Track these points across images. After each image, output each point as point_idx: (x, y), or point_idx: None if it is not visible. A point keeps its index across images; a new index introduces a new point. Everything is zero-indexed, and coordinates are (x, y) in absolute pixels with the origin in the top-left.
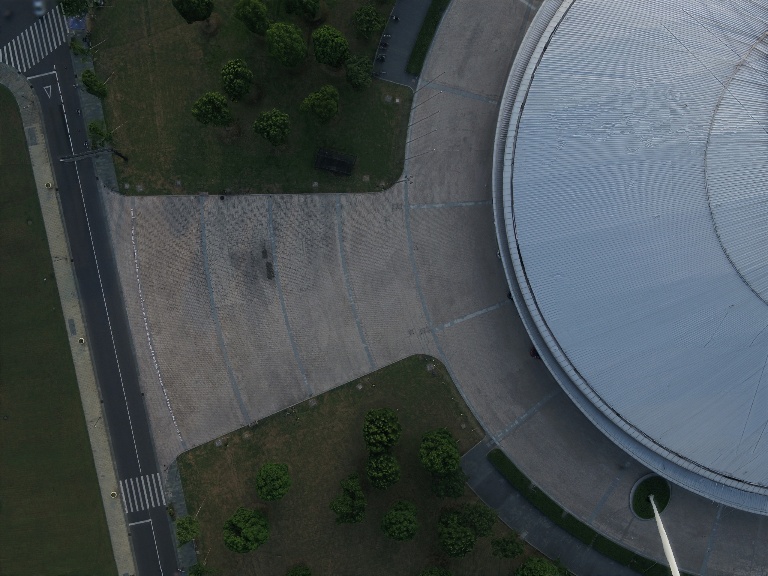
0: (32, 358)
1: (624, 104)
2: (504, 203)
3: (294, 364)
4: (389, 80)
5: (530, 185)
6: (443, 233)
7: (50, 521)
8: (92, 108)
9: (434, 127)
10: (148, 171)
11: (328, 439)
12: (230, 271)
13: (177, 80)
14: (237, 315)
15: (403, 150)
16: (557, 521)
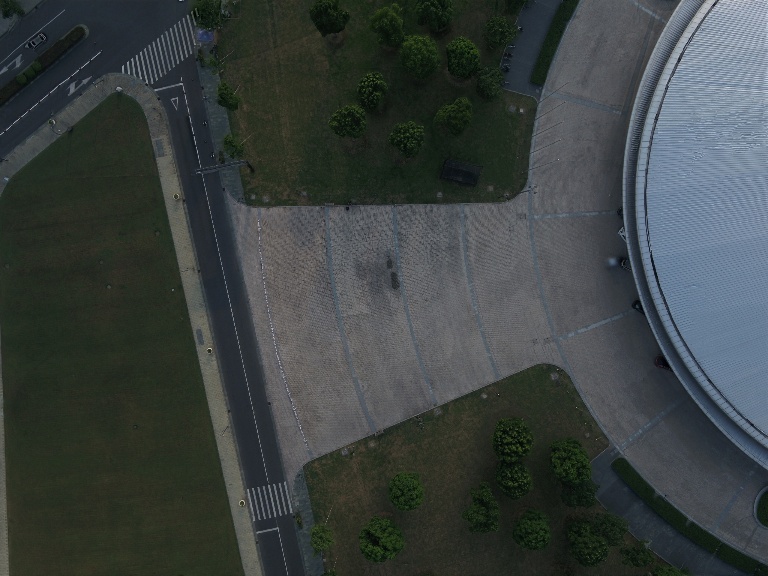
0: (161, 368)
1: (765, 115)
2: (637, 214)
3: (419, 373)
4: (513, 90)
5: (665, 196)
6: (567, 243)
7: (179, 529)
8: (218, 119)
9: (558, 137)
10: (274, 182)
11: (453, 448)
12: (355, 281)
13: (303, 91)
14: (362, 325)
15: (527, 160)
16: (681, 530)
